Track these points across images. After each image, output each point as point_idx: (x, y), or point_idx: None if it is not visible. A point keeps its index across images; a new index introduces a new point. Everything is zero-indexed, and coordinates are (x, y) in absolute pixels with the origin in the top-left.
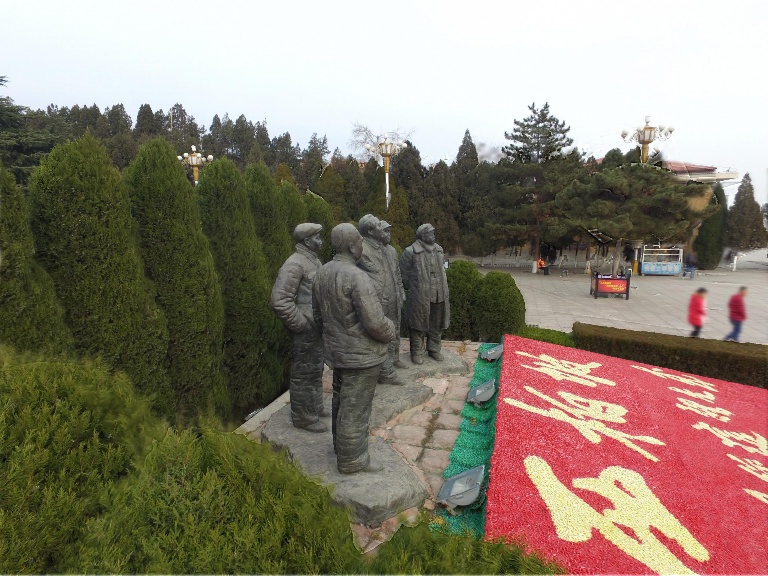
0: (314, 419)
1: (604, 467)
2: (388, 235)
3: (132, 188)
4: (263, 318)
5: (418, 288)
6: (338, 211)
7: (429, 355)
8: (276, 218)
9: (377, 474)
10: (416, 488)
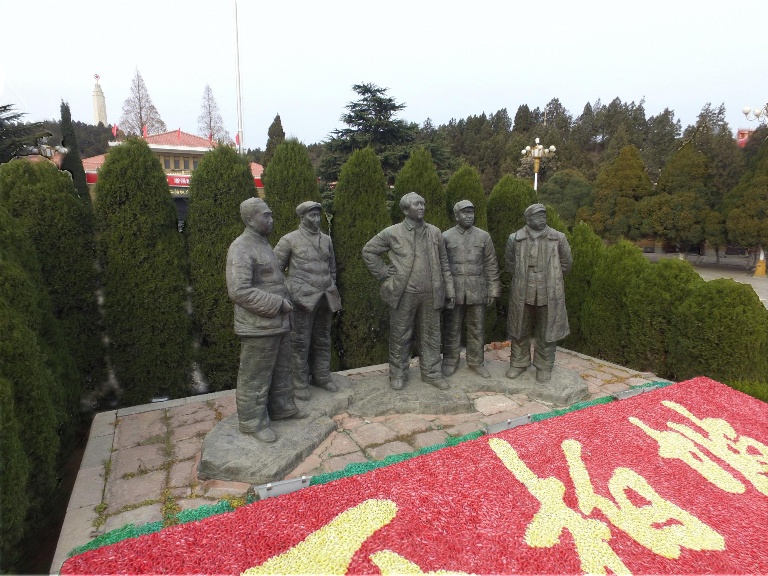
0: (299, 386)
1: (468, 570)
2: (466, 217)
3: (266, 179)
4: (373, 295)
5: (514, 284)
6: (689, 198)
7: (536, 372)
8: None
9: (259, 443)
10: (266, 469)
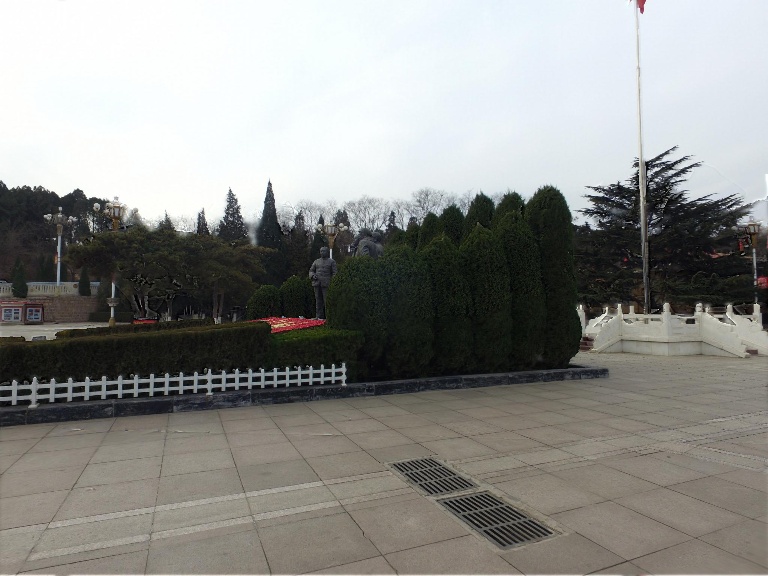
0: None
1: None
2: None
3: None
4: None
5: None
6: None
7: None
8: (464, 231)
9: None
10: None
